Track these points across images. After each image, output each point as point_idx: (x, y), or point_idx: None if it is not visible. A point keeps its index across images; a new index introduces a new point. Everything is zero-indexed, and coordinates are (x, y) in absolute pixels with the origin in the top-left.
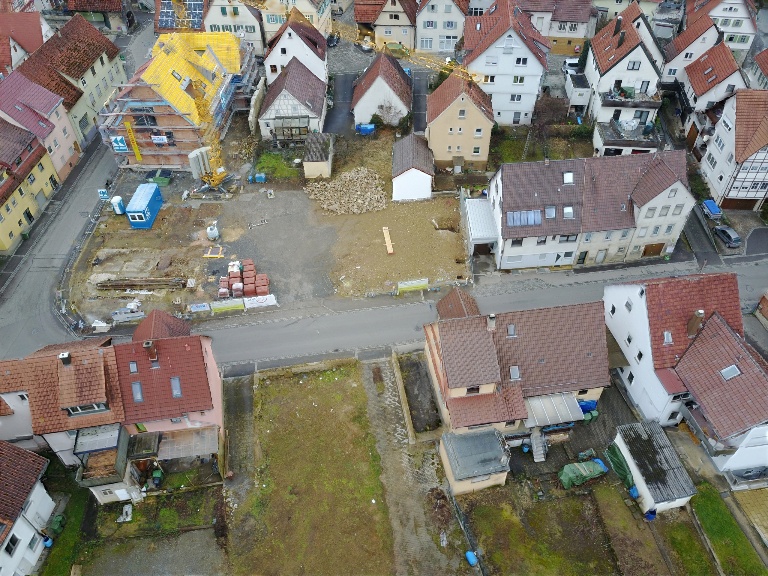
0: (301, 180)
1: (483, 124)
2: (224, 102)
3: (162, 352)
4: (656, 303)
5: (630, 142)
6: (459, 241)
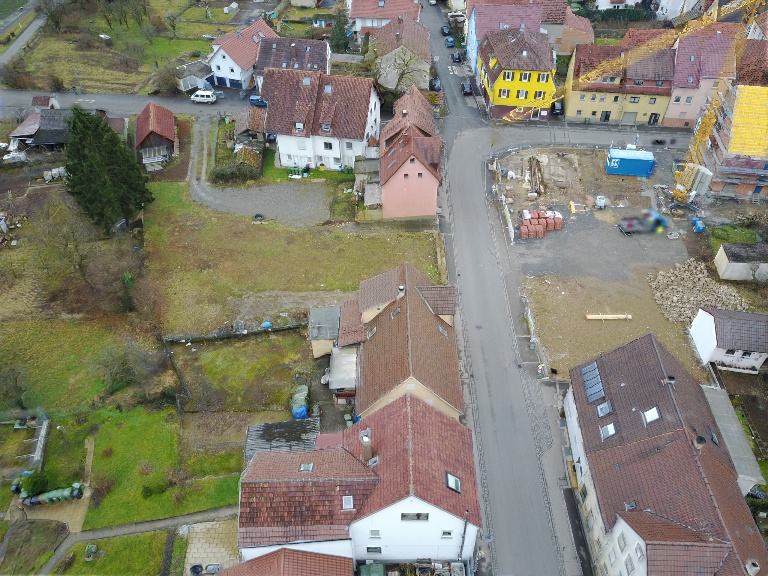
0: (707, 256)
1: None
2: None
3: (406, 146)
4: (392, 411)
5: None
6: None
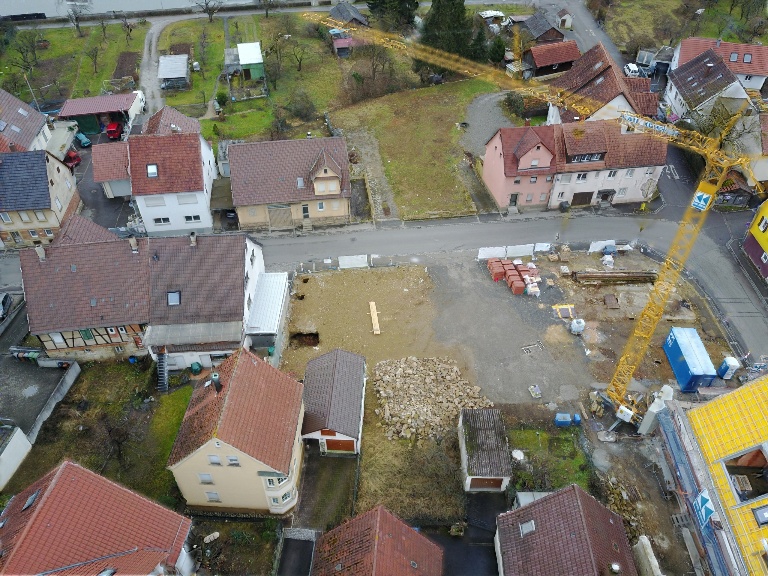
0: None
1: None
2: None
3: None
4: None
5: None
6: (295, 317)
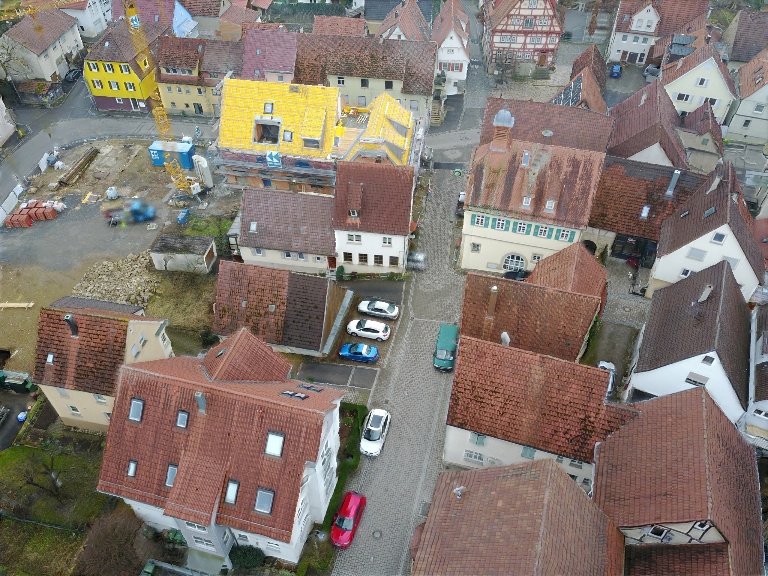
0: None
1: None
2: (278, 164)
3: None
4: None
5: None
6: None
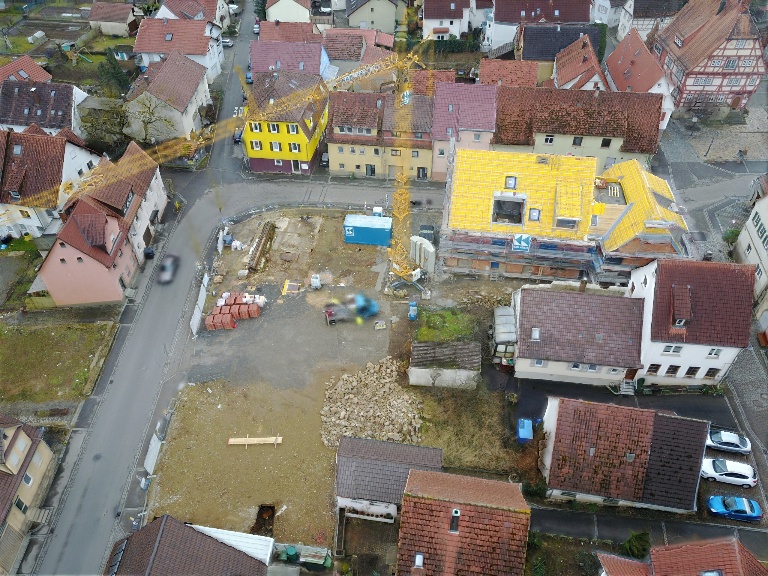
0: (406, 353)
1: None
2: (525, 248)
3: None
4: None
5: None
6: None
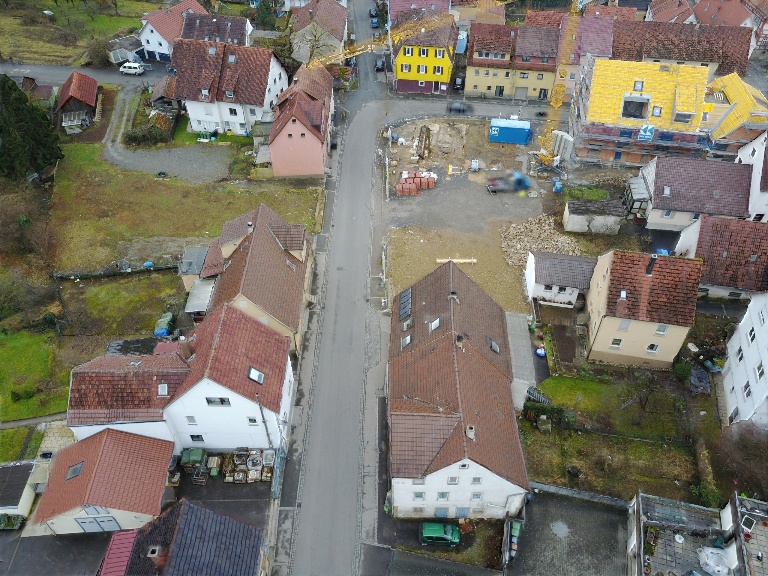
0: (558, 212)
1: (604, 303)
2: (649, 137)
3: None
4: None
5: (639, 528)
6: None
